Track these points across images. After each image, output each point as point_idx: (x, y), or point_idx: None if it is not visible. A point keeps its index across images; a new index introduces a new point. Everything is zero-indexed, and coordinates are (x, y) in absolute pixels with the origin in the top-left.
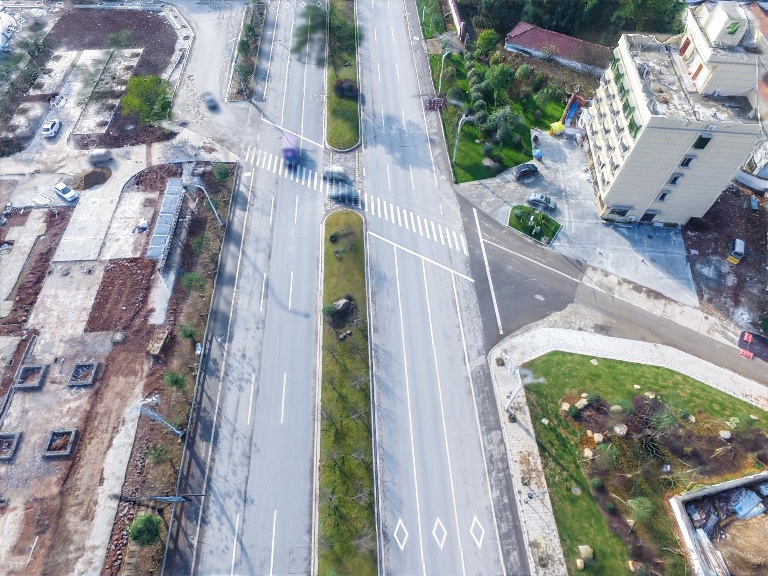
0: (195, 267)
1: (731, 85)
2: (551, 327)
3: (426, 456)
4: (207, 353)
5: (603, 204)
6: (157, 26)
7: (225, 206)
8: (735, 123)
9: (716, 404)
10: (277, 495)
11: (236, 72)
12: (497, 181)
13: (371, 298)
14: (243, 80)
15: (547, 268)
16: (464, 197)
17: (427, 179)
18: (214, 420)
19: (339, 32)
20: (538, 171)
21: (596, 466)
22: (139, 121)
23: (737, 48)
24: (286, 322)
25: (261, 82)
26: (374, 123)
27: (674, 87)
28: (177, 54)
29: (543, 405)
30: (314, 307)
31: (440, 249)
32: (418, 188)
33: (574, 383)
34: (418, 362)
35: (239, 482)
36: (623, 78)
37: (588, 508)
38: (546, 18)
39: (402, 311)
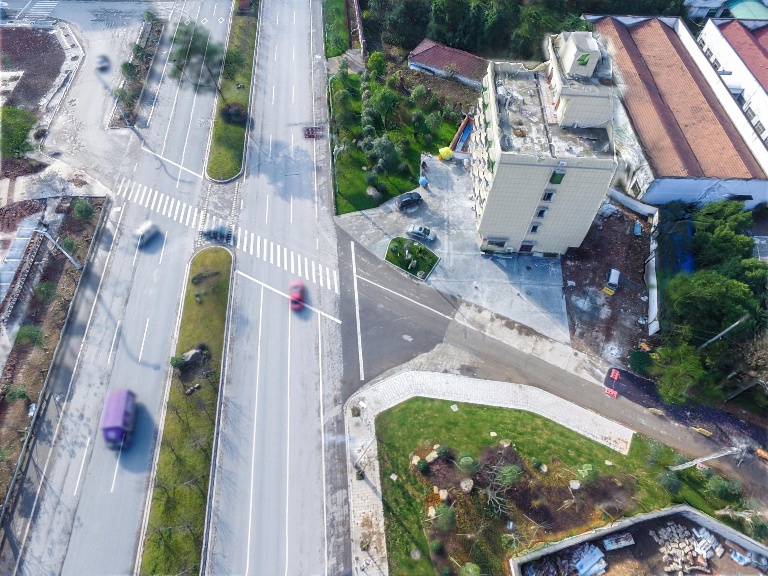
0: (44, 316)
1: (588, 117)
2: (416, 370)
3: (263, 522)
4: (42, 414)
5: (481, 235)
6: (45, 46)
7: (87, 246)
8: (585, 159)
9: (572, 450)
10: (94, 575)
11: (116, 97)
12: (380, 211)
13: (229, 345)
14: (127, 105)
15: (420, 305)
16: (343, 230)
17: (307, 211)
18: (37, 492)
19: (237, 51)
20: (423, 200)
21: (438, 526)
22: (7, 152)
23: (592, 80)
24: (133, 376)
25: (147, 107)
26: (260, 150)
27: (535, 119)
28: (62, 77)
29: (394, 459)
30: (166, 358)
31: (310, 288)
32: (296, 221)
33: (429, 433)
34: (269, 416)
35: (54, 563)
36: (488, 108)
37: (425, 573)
38: (449, 35)
39: (260, 359)
